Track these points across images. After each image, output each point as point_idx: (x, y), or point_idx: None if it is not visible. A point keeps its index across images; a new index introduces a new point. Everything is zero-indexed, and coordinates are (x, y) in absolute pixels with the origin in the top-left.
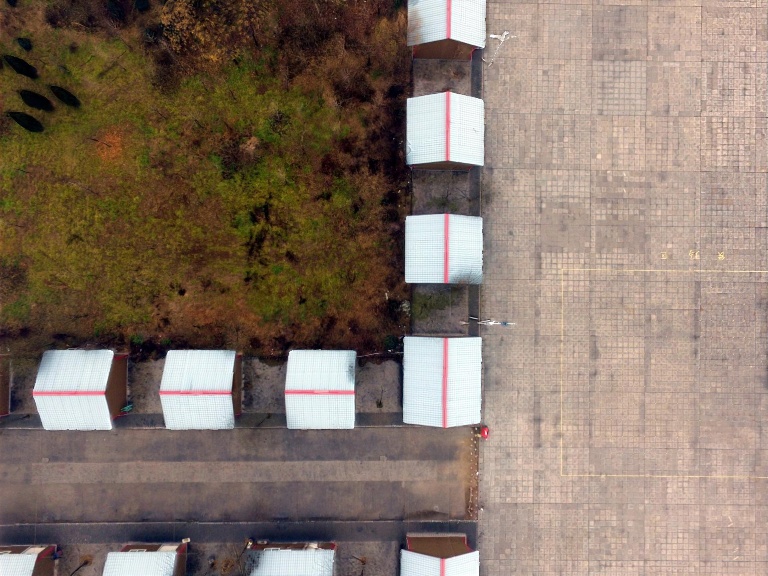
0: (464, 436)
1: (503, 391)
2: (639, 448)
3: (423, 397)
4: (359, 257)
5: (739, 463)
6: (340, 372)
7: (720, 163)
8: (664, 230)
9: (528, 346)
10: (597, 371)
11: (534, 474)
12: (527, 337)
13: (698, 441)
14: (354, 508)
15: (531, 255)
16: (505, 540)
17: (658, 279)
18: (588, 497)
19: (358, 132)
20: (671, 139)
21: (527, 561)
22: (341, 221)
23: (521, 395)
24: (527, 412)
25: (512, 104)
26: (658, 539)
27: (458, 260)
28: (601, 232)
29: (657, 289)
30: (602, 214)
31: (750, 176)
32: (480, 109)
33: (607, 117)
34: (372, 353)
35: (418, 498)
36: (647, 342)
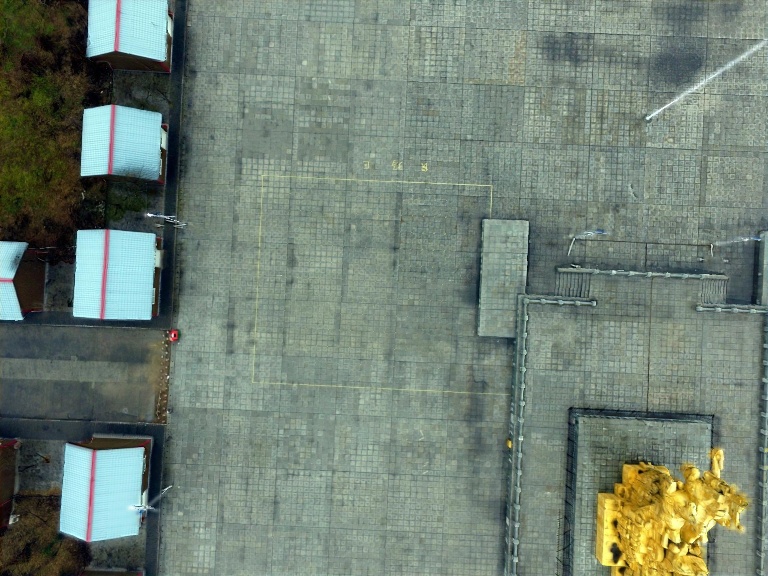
0: (156, 339)
1: (197, 296)
2: (333, 358)
3: (88, 290)
4: (57, 156)
5: (433, 377)
6: (4, 261)
7: (427, 73)
8: (368, 139)
9: (225, 251)
10: (294, 279)
11: (225, 380)
12: (224, 242)
13: (393, 353)
14: (42, 406)
15: (231, 160)
16: (193, 445)
17: (359, 189)
18: (279, 405)
19: (62, 31)
20: (378, 47)
21: (214, 467)
22: (39, 119)
23: (216, 300)
24: (221, 318)
25: (218, 7)
26: (348, 450)
27: (126, 153)
28: (304, 139)
29: (358, 199)
30: (305, 121)
31: (457, 87)
32: (161, 3)
33: (314, 23)
34: (48, 247)
35: (107, 399)
36: (346, 252)
